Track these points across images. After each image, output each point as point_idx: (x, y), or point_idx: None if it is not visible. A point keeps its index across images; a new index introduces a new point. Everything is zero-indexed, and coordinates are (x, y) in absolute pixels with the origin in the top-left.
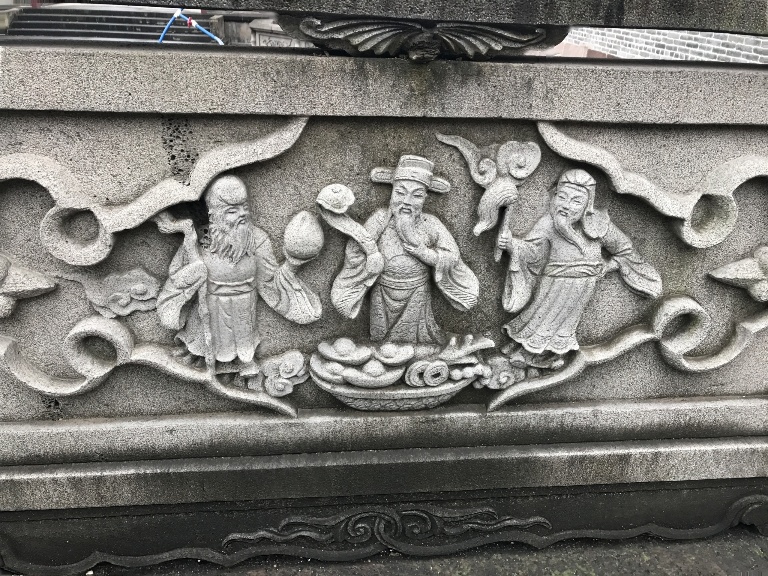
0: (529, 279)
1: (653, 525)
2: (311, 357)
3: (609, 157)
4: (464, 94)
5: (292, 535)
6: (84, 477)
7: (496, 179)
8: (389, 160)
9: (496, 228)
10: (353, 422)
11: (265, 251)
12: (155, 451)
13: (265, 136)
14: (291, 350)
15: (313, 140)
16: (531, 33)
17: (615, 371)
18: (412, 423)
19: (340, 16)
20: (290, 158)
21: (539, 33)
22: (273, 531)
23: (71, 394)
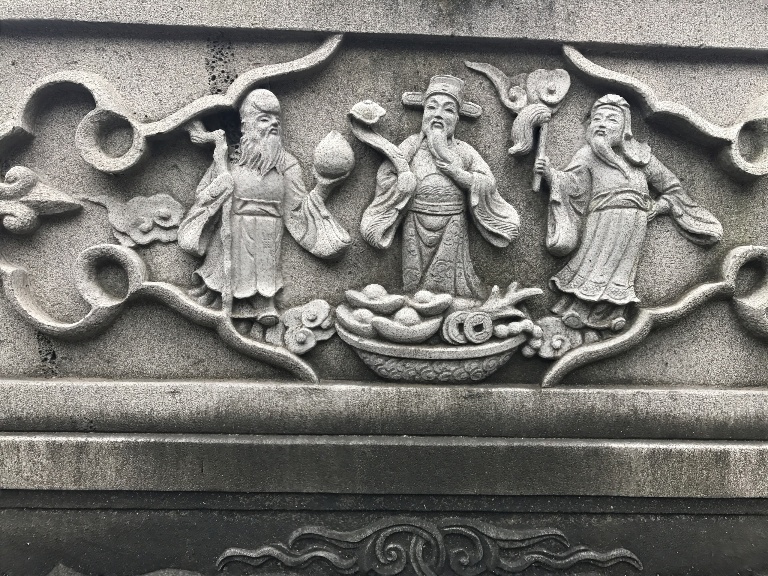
0: (573, 217)
1: None
2: (337, 307)
3: None
4: (489, 15)
5: (305, 555)
6: (66, 443)
7: (527, 105)
8: (420, 87)
9: (532, 160)
10: (383, 392)
11: (294, 174)
12: (152, 420)
13: (301, 57)
14: None
15: (347, 65)
16: None
17: (688, 344)
18: (453, 398)
19: None
20: (324, 83)
21: None
22: (281, 547)
23: (72, 329)
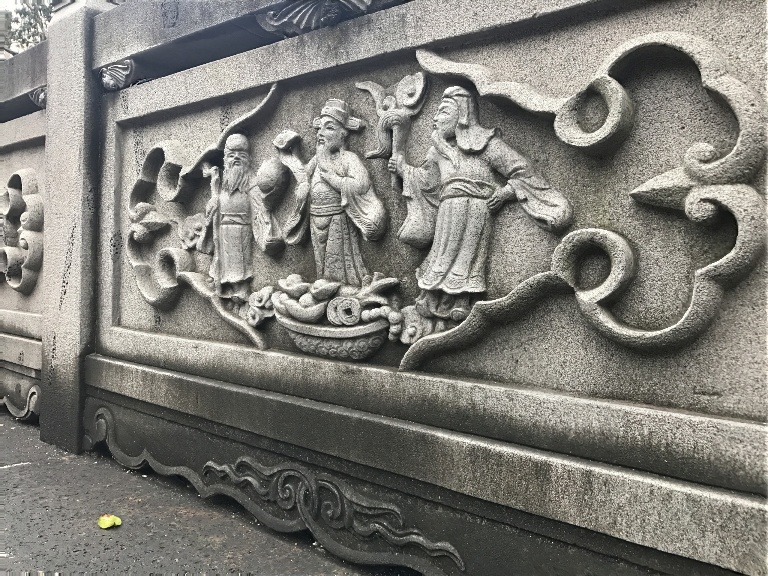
0: (427, 210)
1: None
2: None
3: (477, 67)
4: (361, 41)
5: (242, 477)
6: (148, 372)
7: None
8: None
9: None
10: (295, 361)
11: (255, 193)
12: (187, 365)
13: None
14: None
15: (287, 105)
16: None
17: (538, 341)
18: (336, 372)
19: (282, 4)
20: (276, 121)
21: None
22: (232, 467)
23: (155, 301)
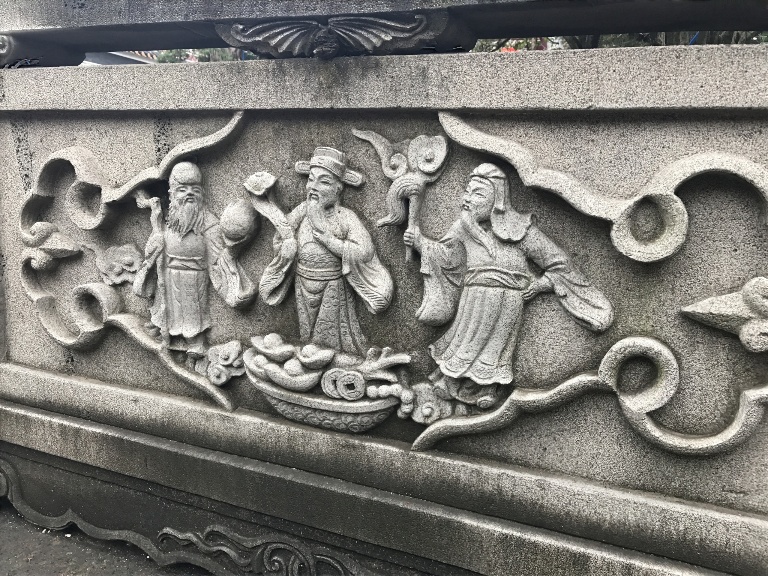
0: (448, 289)
1: None
2: (248, 349)
3: (517, 148)
4: (365, 86)
5: (214, 547)
6: (68, 426)
7: (406, 173)
8: None
9: None
10: (277, 428)
11: (213, 234)
12: (123, 419)
13: None
14: (235, 340)
15: (255, 136)
16: (414, 21)
17: (570, 432)
18: (332, 444)
19: (256, 20)
20: (238, 152)
21: (418, 19)
22: (199, 536)
23: (71, 345)
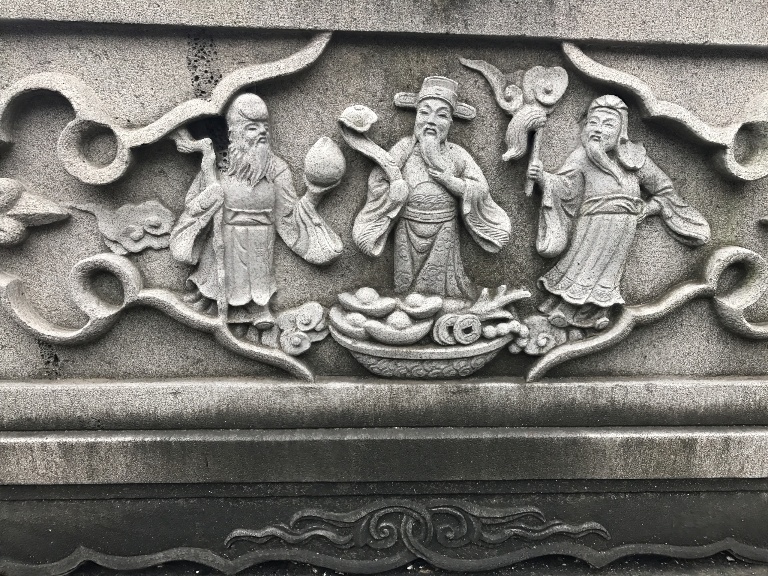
0: (564, 220)
1: (732, 540)
2: (331, 309)
3: (639, 80)
4: (486, 10)
5: (305, 534)
6: (76, 443)
7: (523, 106)
8: (413, 86)
9: (526, 162)
10: (376, 389)
11: (285, 181)
12: (157, 418)
13: (288, 56)
14: (309, 302)
15: (336, 63)
16: None
17: (668, 338)
18: (442, 393)
19: None
20: (313, 82)
21: None
22: (284, 528)
23: (72, 338)
